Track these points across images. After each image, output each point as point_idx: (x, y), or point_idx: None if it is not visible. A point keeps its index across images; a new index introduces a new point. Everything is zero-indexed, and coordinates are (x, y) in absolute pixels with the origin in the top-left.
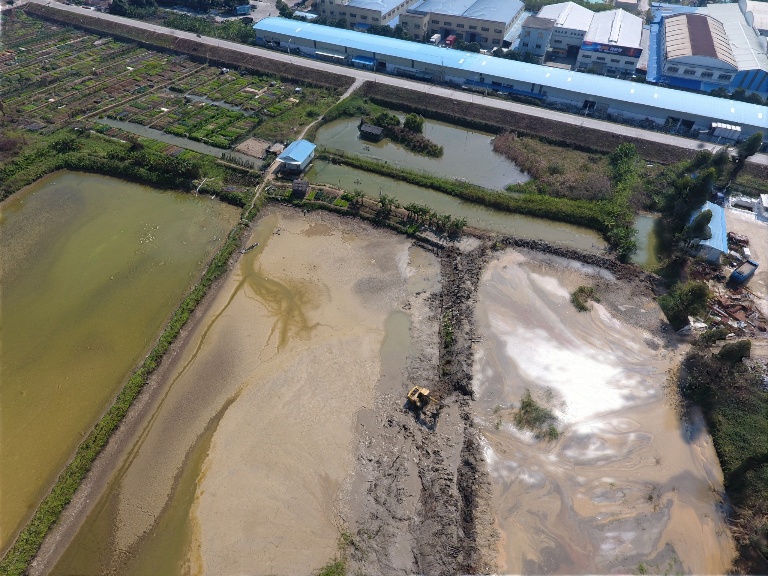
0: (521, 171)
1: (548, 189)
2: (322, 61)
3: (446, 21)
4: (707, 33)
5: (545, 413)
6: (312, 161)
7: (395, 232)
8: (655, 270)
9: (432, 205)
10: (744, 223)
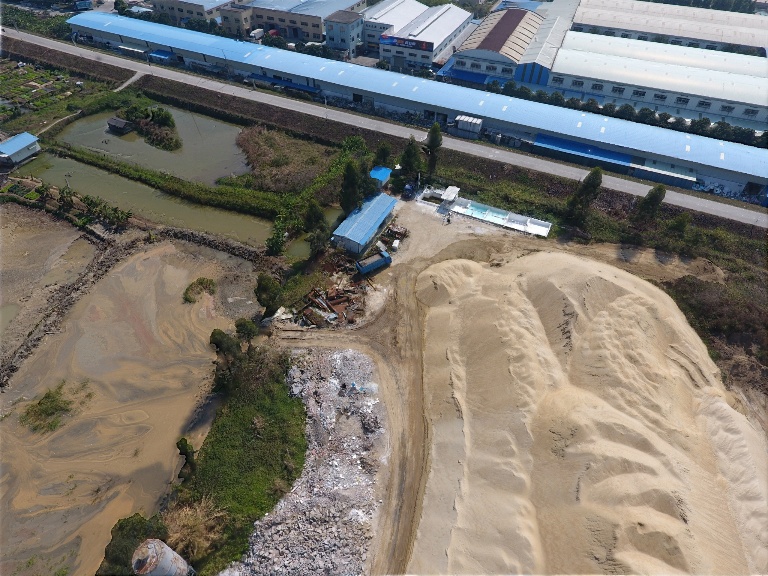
0: (247, 164)
1: (255, 182)
2: (116, 55)
3: (268, 16)
4: (511, 27)
5: (56, 405)
6: (39, 154)
7: (70, 225)
8: (296, 262)
9: (116, 197)
10: (420, 215)
